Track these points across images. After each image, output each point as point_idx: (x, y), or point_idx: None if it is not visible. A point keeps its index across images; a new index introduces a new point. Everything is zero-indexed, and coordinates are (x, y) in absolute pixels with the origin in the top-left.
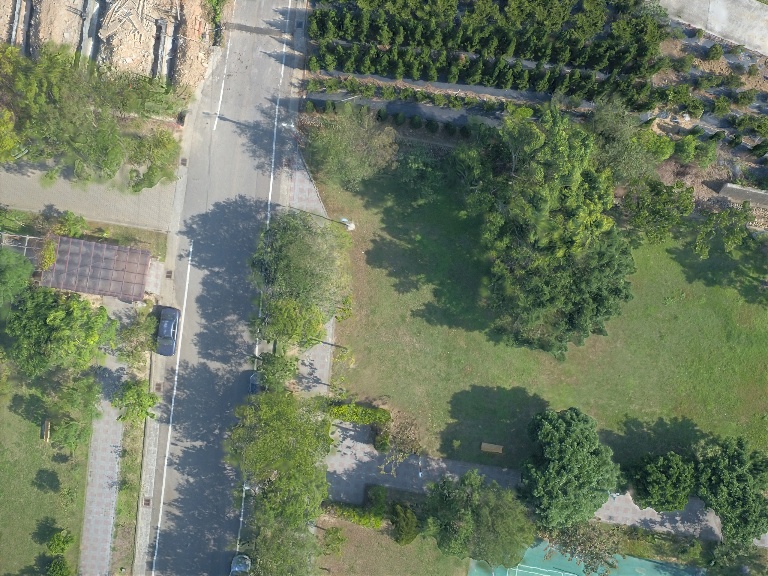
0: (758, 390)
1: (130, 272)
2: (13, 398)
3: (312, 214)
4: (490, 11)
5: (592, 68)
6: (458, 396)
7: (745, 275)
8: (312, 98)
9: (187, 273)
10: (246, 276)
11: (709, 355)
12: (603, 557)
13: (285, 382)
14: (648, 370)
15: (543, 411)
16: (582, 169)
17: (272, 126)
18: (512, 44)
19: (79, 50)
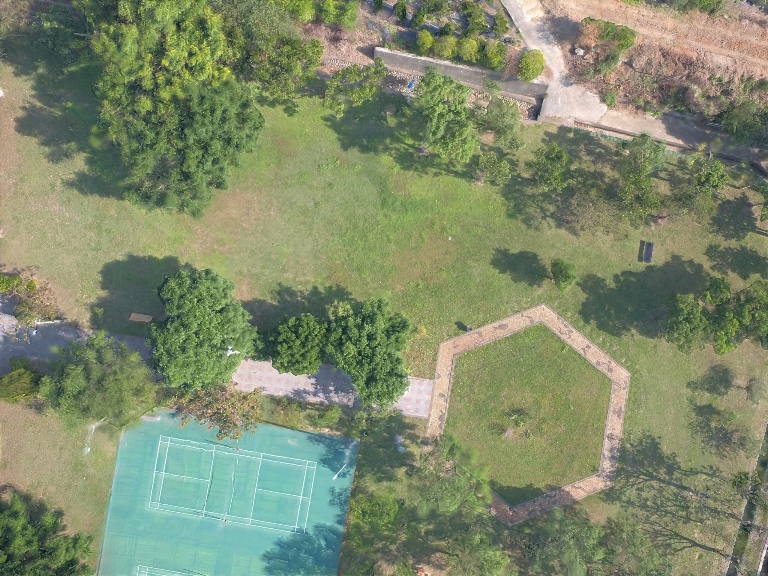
0: (413, 258)
1: None
2: None
3: None
4: None
5: None
6: (109, 266)
7: (400, 142)
8: None
9: None
10: None
11: (364, 223)
12: (232, 419)
13: None
14: (302, 238)
15: None
16: (192, 16)
17: None
18: None
19: None
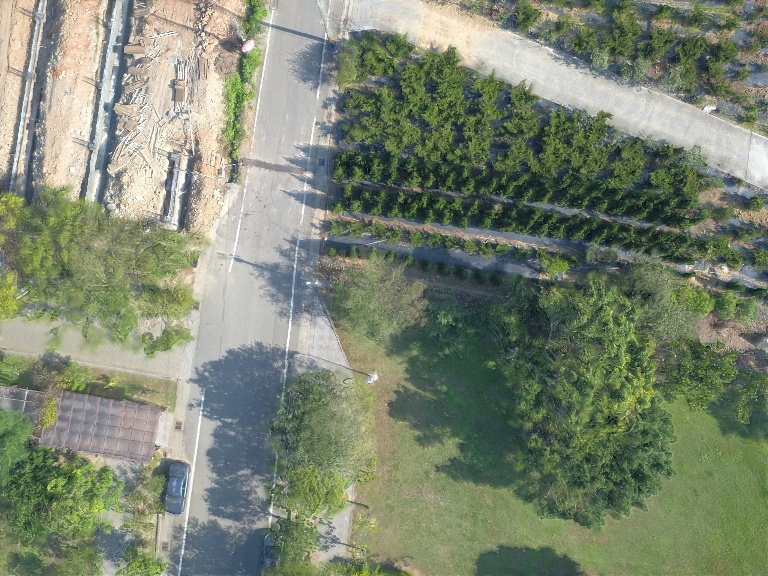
0: None
1: (138, 430)
2: (7, 556)
3: (333, 363)
4: (523, 157)
5: (628, 217)
6: (485, 558)
7: None
8: (334, 241)
9: (198, 424)
10: (261, 428)
11: (746, 516)
12: None
13: (301, 541)
14: (683, 531)
15: (574, 574)
16: None
17: (291, 269)
18: (547, 195)
19: (85, 182)
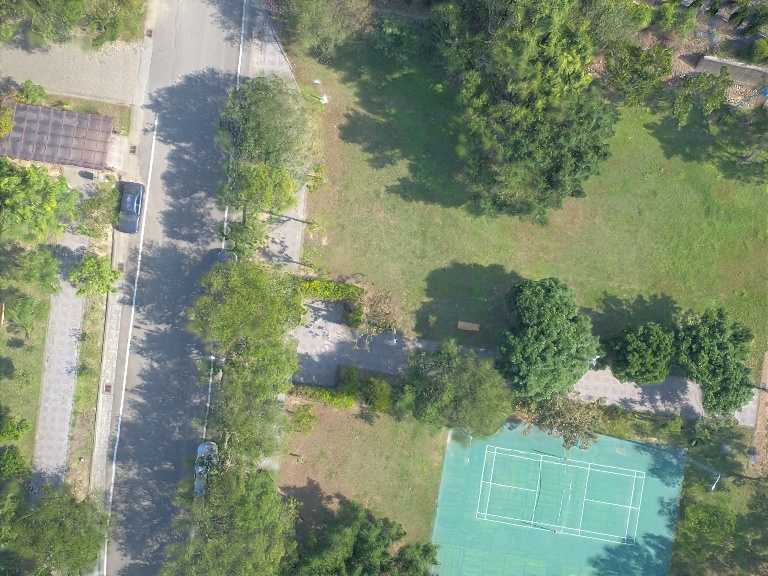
0: (737, 267)
1: (91, 139)
2: None
3: None
4: None
5: None
6: (434, 274)
7: (722, 151)
8: None
9: (152, 148)
10: (214, 151)
11: (688, 231)
12: (583, 429)
13: (254, 261)
14: (627, 247)
15: None
16: (559, 24)
17: None
18: None
19: None
